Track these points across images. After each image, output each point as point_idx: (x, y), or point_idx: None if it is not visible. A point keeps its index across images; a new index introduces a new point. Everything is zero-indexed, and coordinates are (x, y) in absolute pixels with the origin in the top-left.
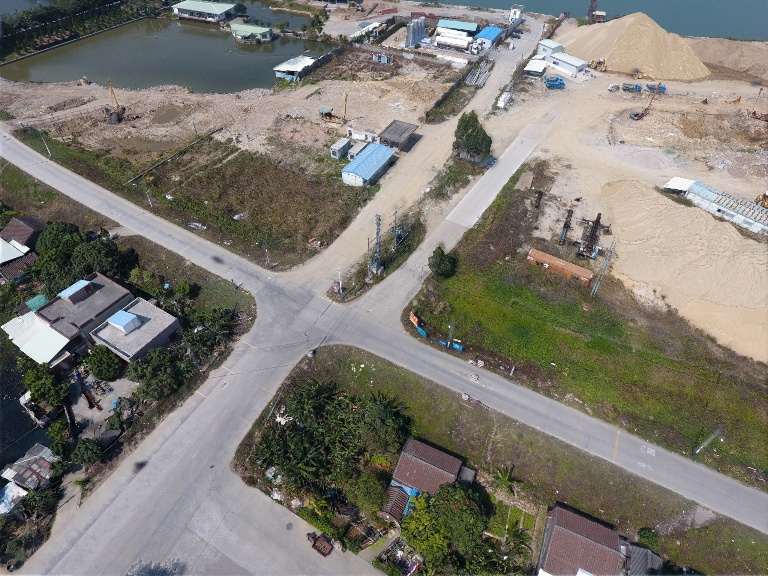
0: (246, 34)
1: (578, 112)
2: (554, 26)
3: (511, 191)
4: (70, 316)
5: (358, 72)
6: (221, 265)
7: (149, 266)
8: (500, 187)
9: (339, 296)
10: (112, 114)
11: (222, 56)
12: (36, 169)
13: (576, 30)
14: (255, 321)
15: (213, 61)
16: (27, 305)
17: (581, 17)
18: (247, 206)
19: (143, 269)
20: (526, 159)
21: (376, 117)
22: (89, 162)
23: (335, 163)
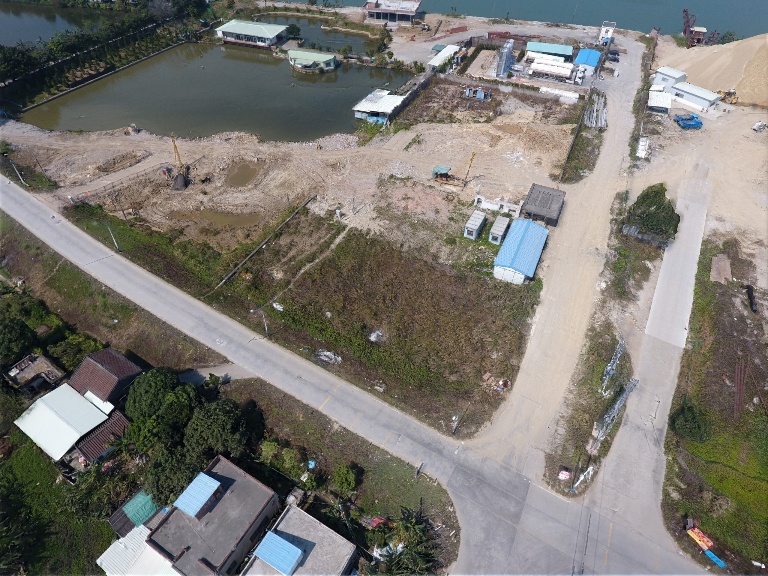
0: (308, 63)
1: (732, 161)
2: (653, 46)
3: (709, 285)
4: (198, 544)
5: (454, 111)
6: (383, 430)
7: (280, 429)
8: (692, 278)
9: (565, 485)
10: (177, 177)
11: (284, 90)
12: (101, 269)
13: (687, 52)
14: (460, 537)
15: (275, 97)
16: (129, 518)
17: (678, 34)
18: (383, 319)
19: (273, 434)
20: (703, 233)
21: (498, 175)
22: (162, 250)
23: (471, 245)
